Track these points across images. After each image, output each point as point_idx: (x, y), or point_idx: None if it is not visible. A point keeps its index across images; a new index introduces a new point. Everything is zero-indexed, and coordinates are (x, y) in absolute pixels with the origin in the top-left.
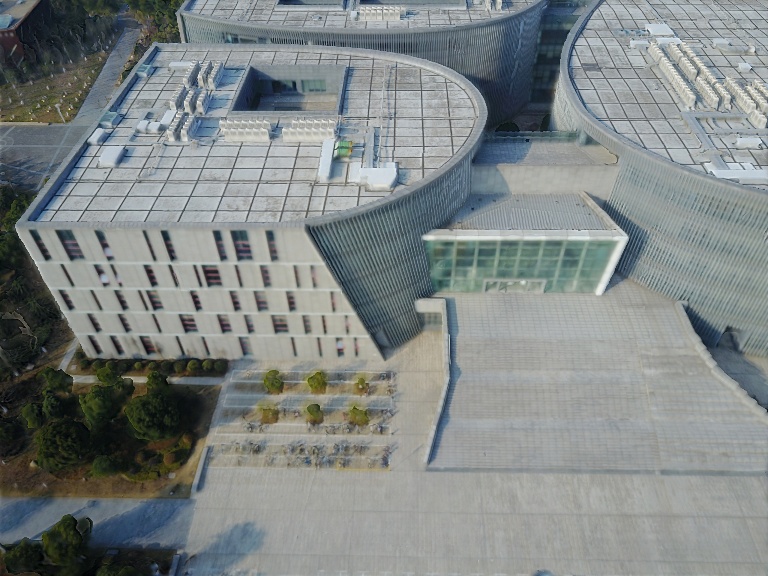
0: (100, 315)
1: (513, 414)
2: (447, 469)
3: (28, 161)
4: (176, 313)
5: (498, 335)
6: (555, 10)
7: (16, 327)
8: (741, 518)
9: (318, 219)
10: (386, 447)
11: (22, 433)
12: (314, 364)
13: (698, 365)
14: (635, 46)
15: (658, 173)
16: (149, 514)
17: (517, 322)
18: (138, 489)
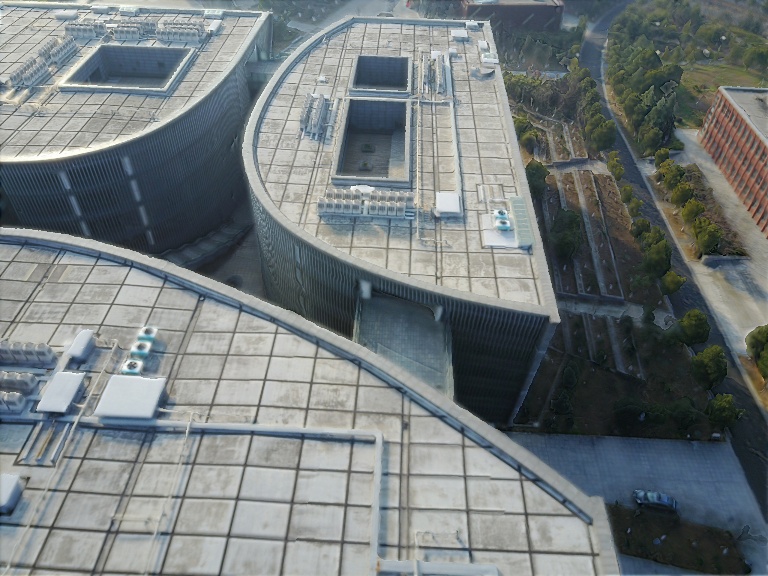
0: None
1: None
2: None
3: None
4: None
5: None
6: (430, 335)
7: None
8: None
9: None
10: None
11: None
12: None
13: None
14: None
15: None
16: None
17: None
18: None
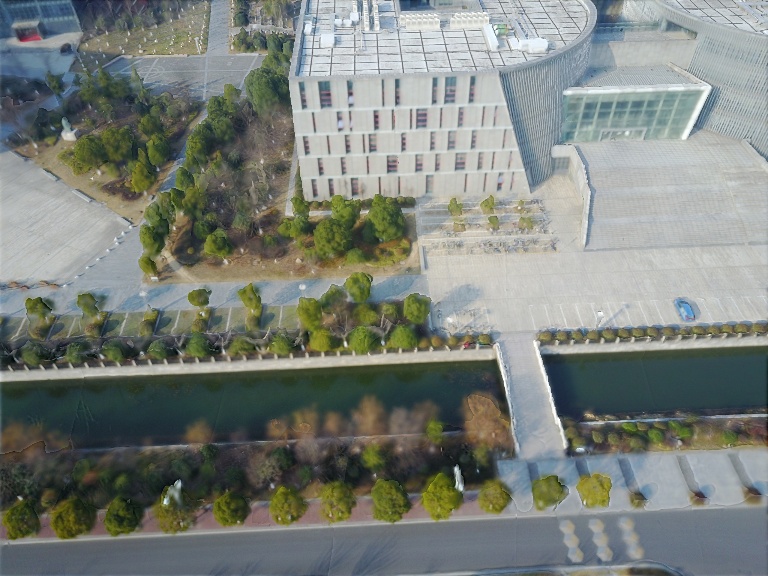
0: (327, 159)
1: (639, 214)
2: (599, 249)
3: (185, 82)
4: (385, 155)
5: (618, 165)
6: None
7: (244, 182)
8: None
9: (506, 68)
10: (551, 239)
11: (281, 244)
12: (479, 198)
13: (765, 177)
14: None
15: (730, 39)
16: (396, 284)
17: (630, 157)
18: (382, 271)
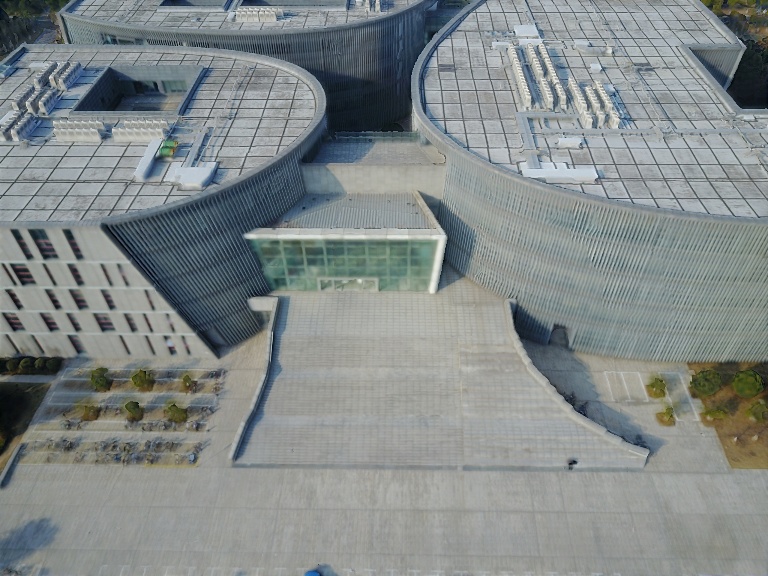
0: None
1: (326, 411)
2: (253, 465)
3: None
4: None
5: (323, 333)
6: (445, 11)
7: None
8: (531, 513)
9: (116, 218)
10: (197, 444)
11: None
12: (148, 362)
13: (515, 362)
14: (496, 47)
15: (476, 172)
16: None
17: (345, 320)
18: None
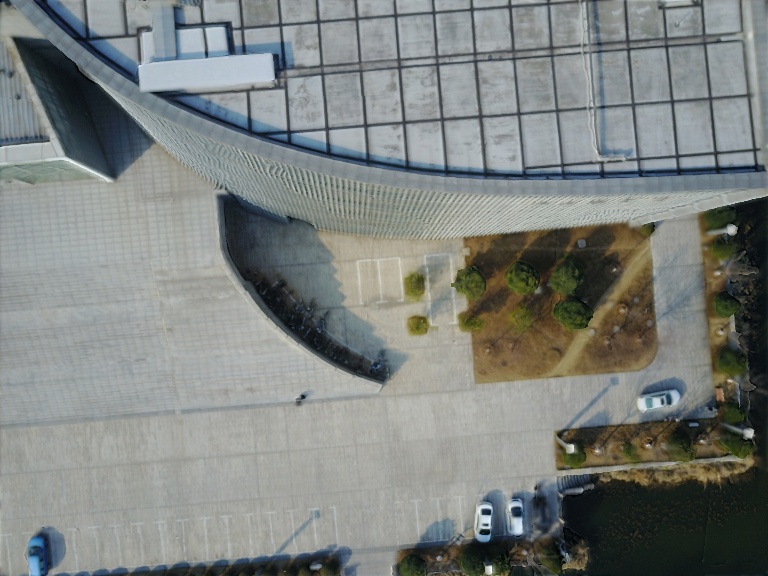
0: None
1: (9, 367)
2: None
3: None
4: None
5: None
6: None
7: None
8: (253, 455)
9: None
10: None
11: None
12: None
13: (228, 288)
14: None
15: None
16: None
17: None
18: None
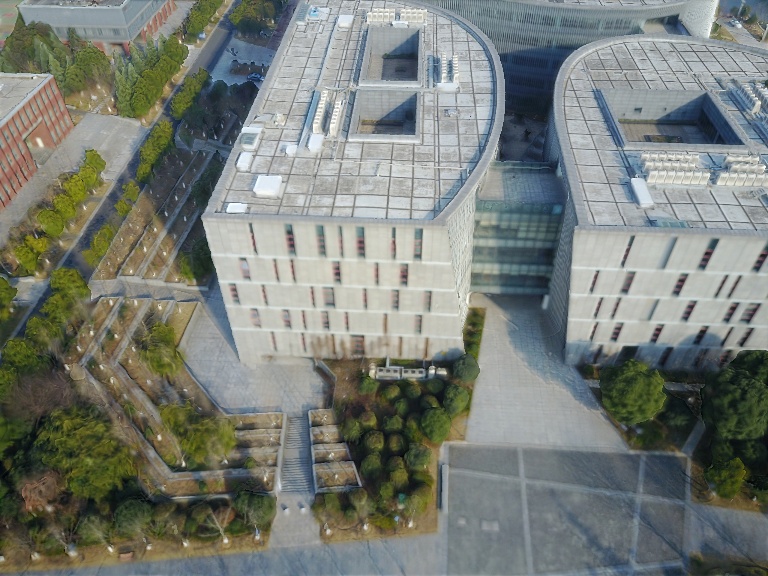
0: None
1: None
2: None
3: None
4: None
5: None
6: None
7: None
8: None
9: None
10: None
11: None
12: None
13: None
14: None
15: (700, 4)
16: None
17: None
18: None
